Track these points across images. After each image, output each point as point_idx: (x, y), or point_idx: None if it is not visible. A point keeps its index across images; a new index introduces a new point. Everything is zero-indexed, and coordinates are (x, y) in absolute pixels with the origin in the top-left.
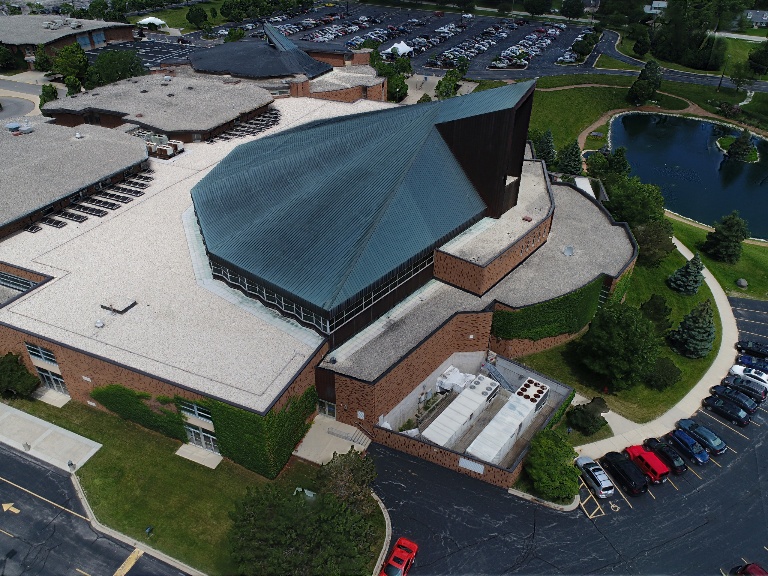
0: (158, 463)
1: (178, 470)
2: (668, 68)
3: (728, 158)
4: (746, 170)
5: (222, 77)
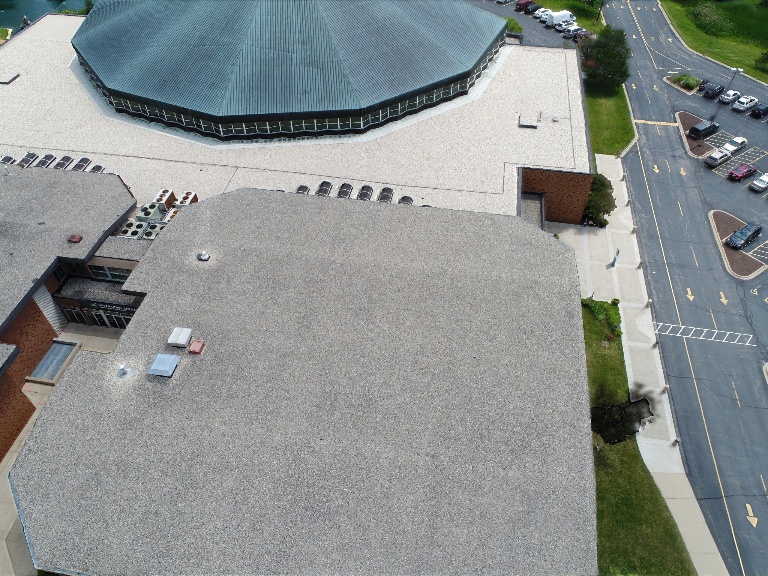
0: (590, 129)
1: (588, 121)
2: None
3: None
4: None
5: None
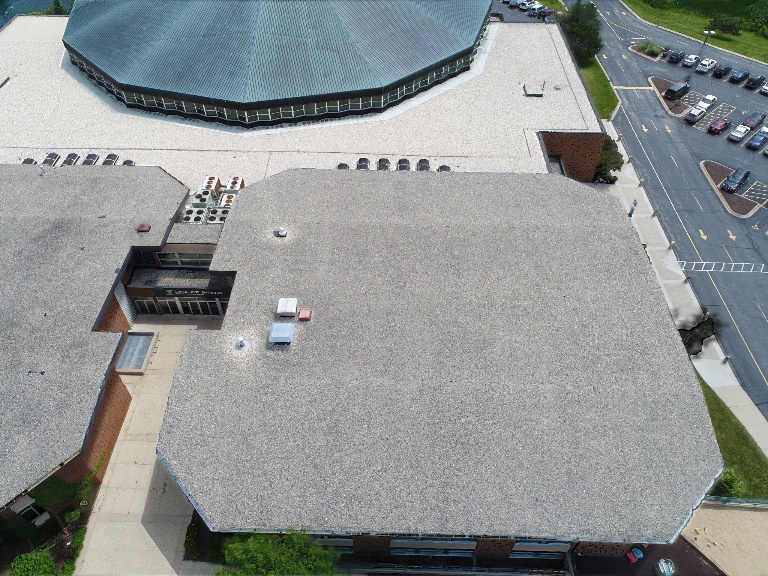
0: None
1: None
2: None
3: None
4: None
5: None
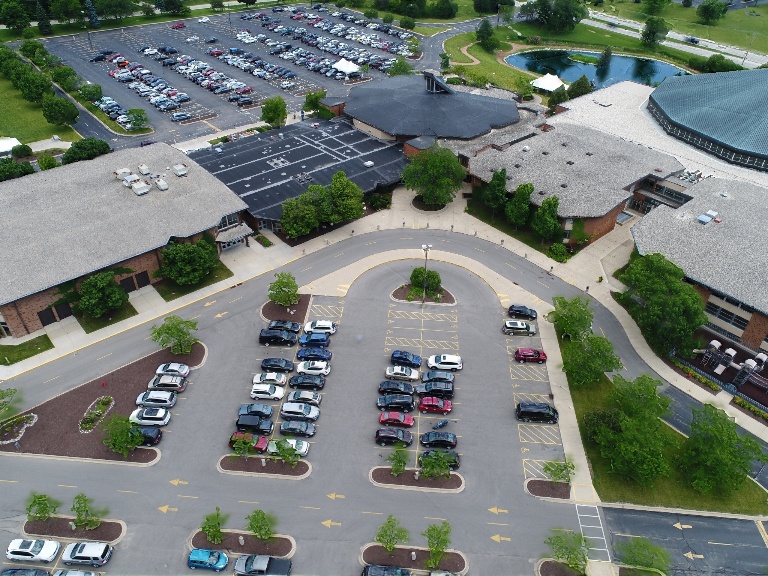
0: None
1: None
2: (444, 23)
3: (599, 67)
4: (611, 70)
5: (497, 133)
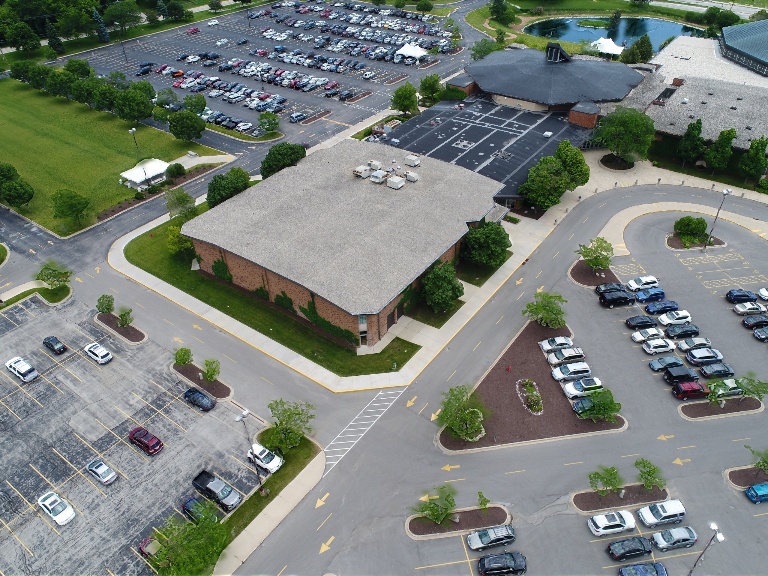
0: None
1: None
2: (446, 3)
3: (610, 29)
4: None
5: (636, 92)
